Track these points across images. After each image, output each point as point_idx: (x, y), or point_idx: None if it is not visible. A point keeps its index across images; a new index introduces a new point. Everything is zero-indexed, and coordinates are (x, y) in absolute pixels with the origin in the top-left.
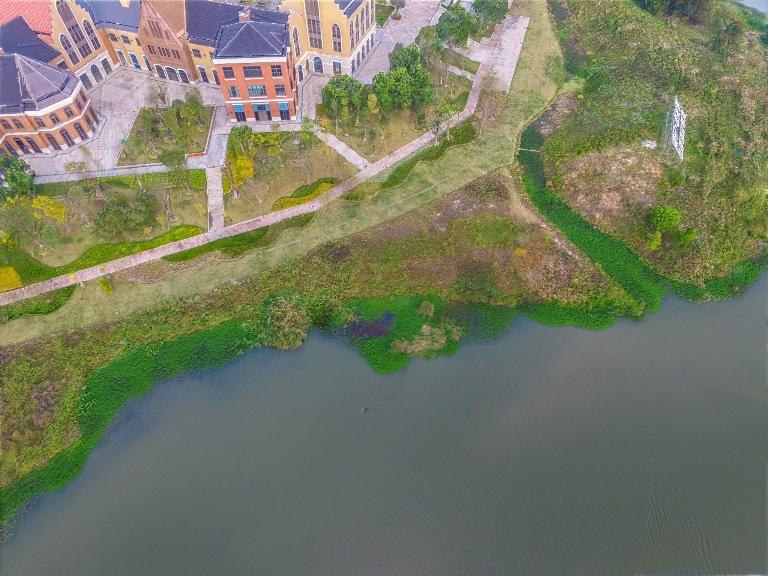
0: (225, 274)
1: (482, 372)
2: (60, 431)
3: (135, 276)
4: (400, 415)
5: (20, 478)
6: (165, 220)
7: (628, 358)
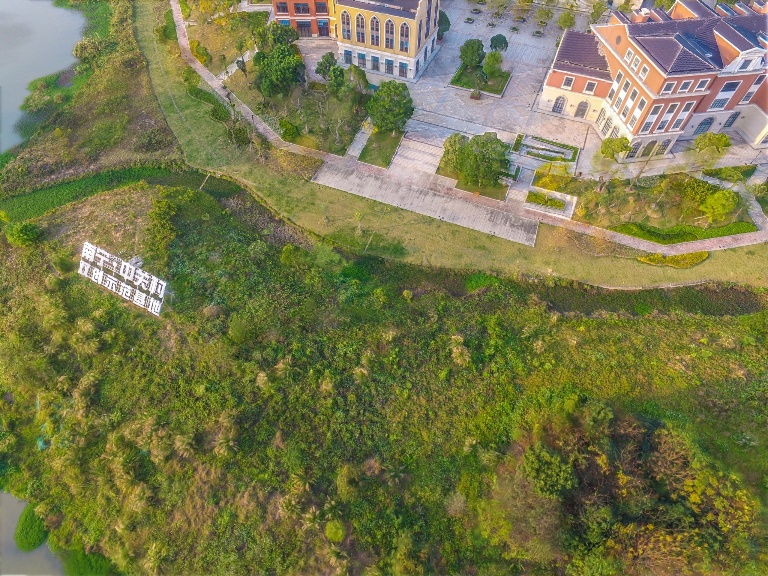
0: (144, 29)
1: None
2: None
3: (162, 4)
4: None
5: None
6: (191, 0)
7: None
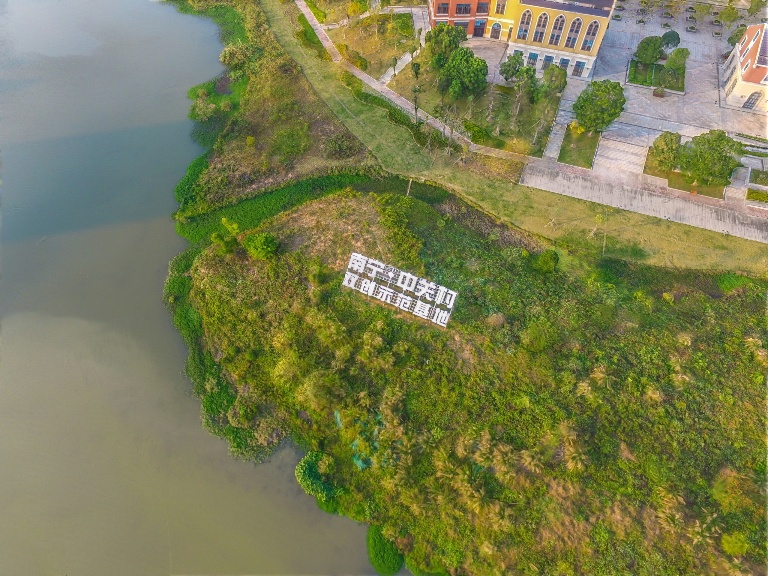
0: (283, 33)
1: (170, 128)
2: (203, 5)
3: (290, 8)
4: (158, 93)
5: (186, 1)
6: (325, 4)
7: (144, 200)
